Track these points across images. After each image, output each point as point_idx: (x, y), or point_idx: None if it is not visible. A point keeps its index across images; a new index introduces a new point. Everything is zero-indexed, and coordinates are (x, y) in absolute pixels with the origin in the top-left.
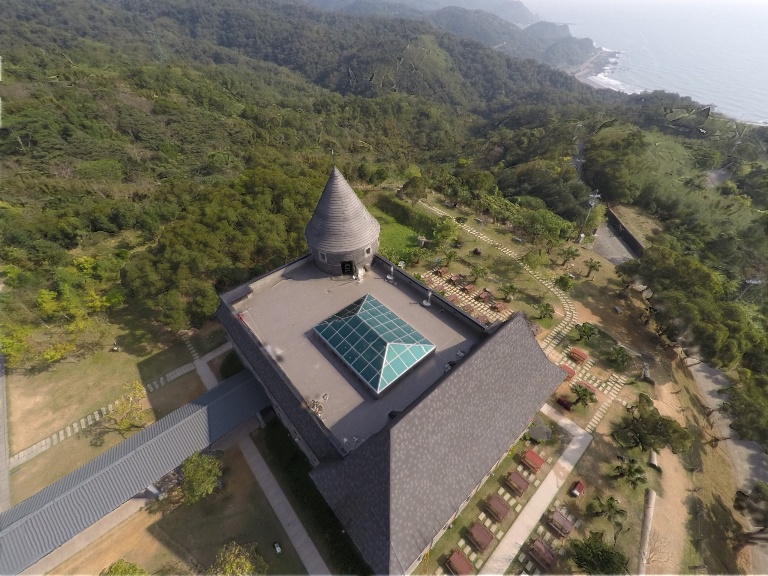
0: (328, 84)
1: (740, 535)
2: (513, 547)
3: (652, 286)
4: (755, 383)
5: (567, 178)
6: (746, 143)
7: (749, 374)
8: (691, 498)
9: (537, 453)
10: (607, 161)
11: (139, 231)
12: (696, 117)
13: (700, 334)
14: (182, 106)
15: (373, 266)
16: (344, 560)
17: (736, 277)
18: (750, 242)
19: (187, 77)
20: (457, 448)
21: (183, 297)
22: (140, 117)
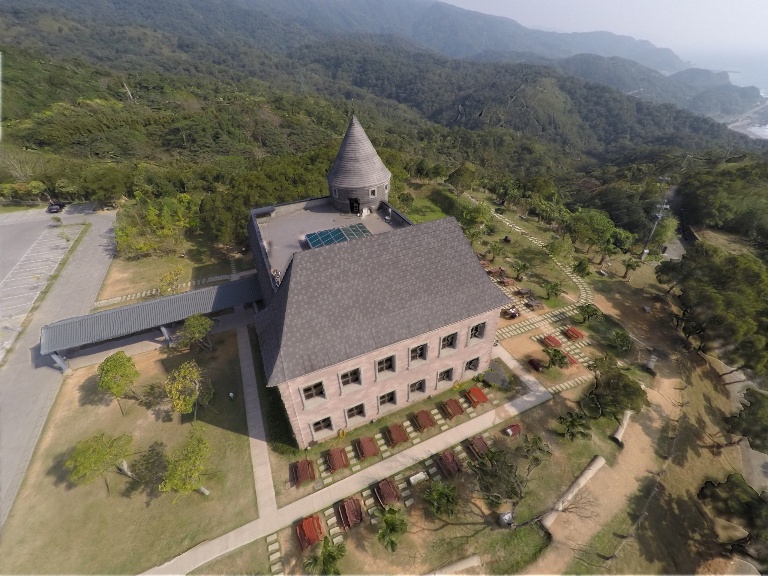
0: (437, 117)
1: (711, 542)
2: (424, 452)
3: (686, 283)
4: None
5: (648, 198)
6: None
7: None
8: (650, 479)
9: (485, 394)
10: (702, 184)
11: (228, 186)
12: None
13: (717, 323)
14: None
15: (379, 211)
16: (276, 416)
17: None
18: None
19: (317, 105)
20: (363, 307)
21: (233, 219)
22: (270, 129)
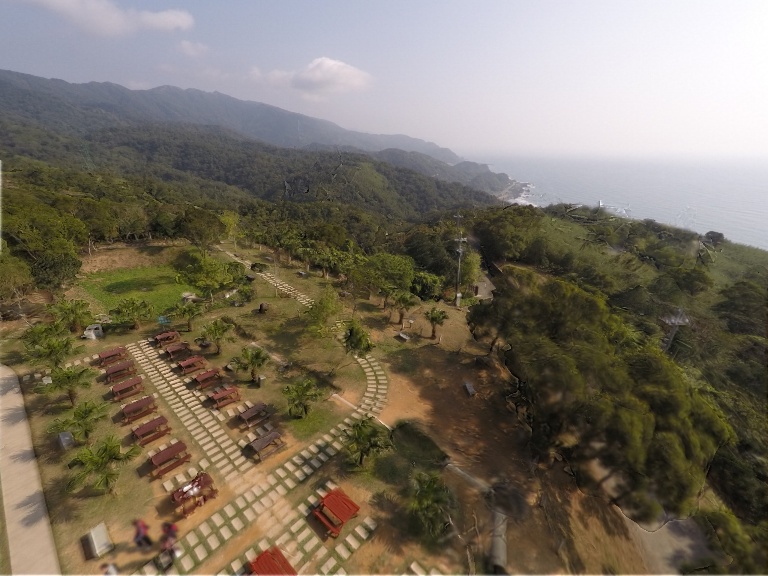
0: (264, 194)
1: None
2: None
3: (508, 336)
4: (760, 558)
5: (449, 239)
6: (637, 222)
7: (737, 529)
8: None
9: None
10: (492, 221)
11: None
12: (590, 207)
13: (589, 427)
14: None
15: None
16: None
17: (658, 333)
18: (664, 295)
19: (105, 182)
20: None
21: None
22: None
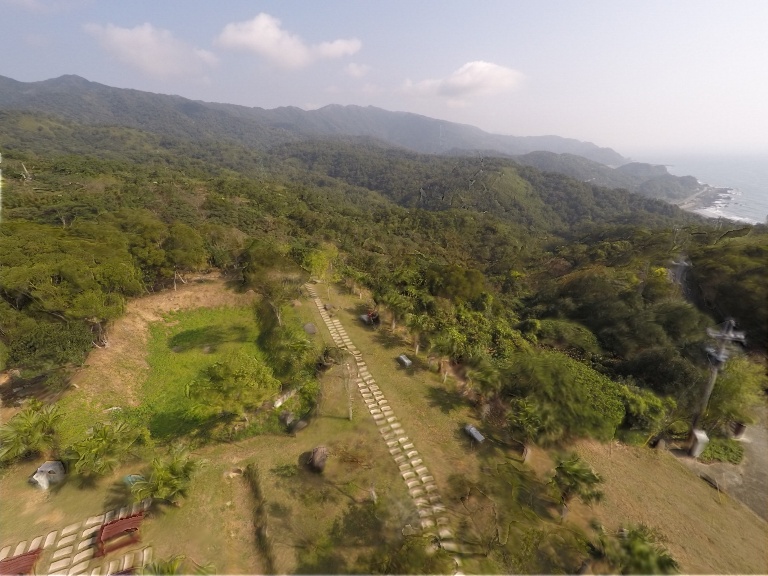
0: None
1: None
2: None
3: None
4: None
5: (655, 296)
6: None
7: None
8: None
9: None
10: (745, 271)
11: None
12: None
13: None
14: (230, 204)
15: None
16: None
17: None
18: None
19: None
20: None
21: None
22: (186, 210)
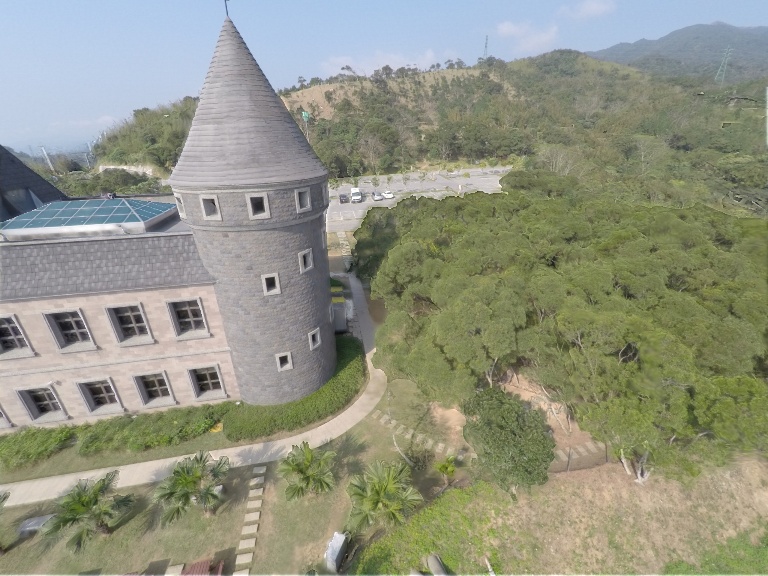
0: None
1: None
2: None
3: None
4: None
5: None
6: None
7: None
8: None
9: None
10: None
11: None
12: None
13: None
14: None
15: None
16: None
17: None
18: None
19: None
20: None
21: None
22: None
